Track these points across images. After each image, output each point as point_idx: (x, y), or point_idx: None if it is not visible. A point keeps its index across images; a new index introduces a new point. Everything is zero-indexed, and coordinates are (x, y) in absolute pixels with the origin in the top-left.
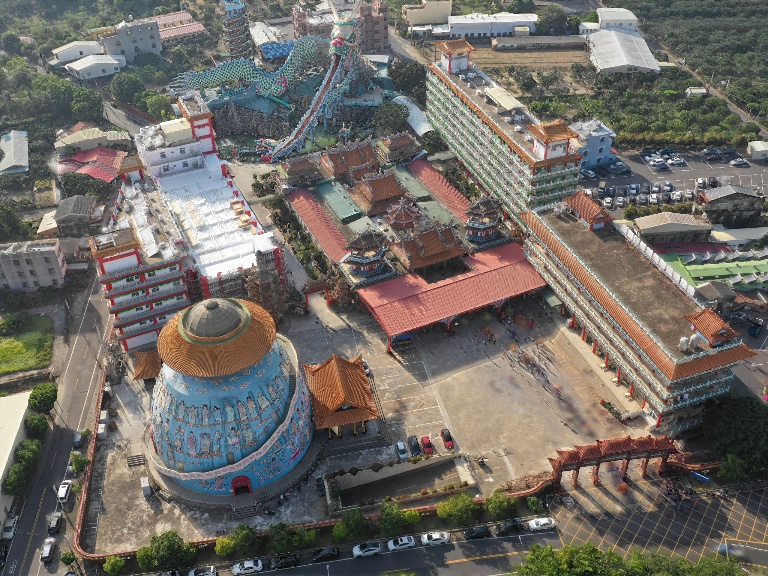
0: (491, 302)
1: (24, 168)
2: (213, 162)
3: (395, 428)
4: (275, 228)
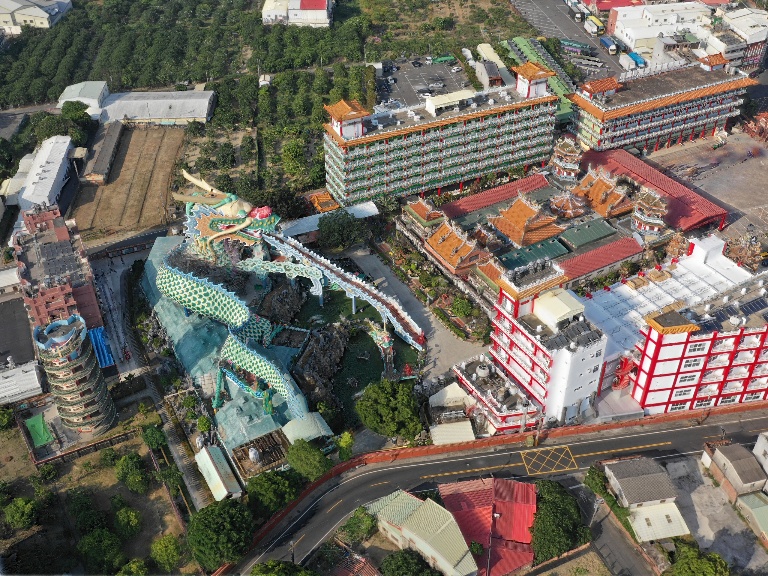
0: None
1: None
2: None
3: None
4: None
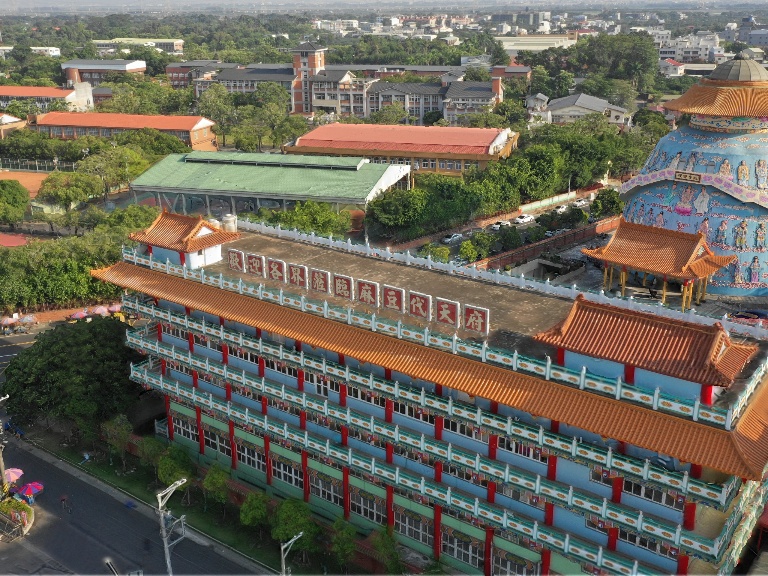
0: None
1: None
2: None
3: None
4: None
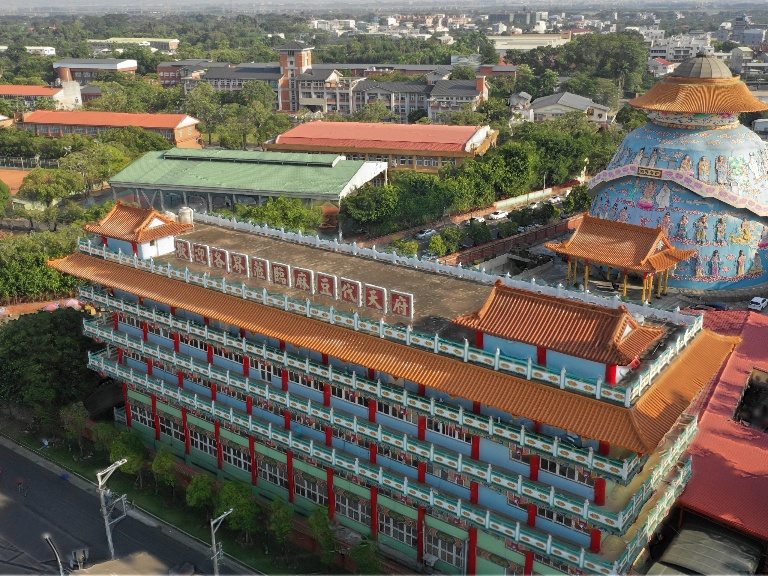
0: None
1: None
2: None
3: None
4: None
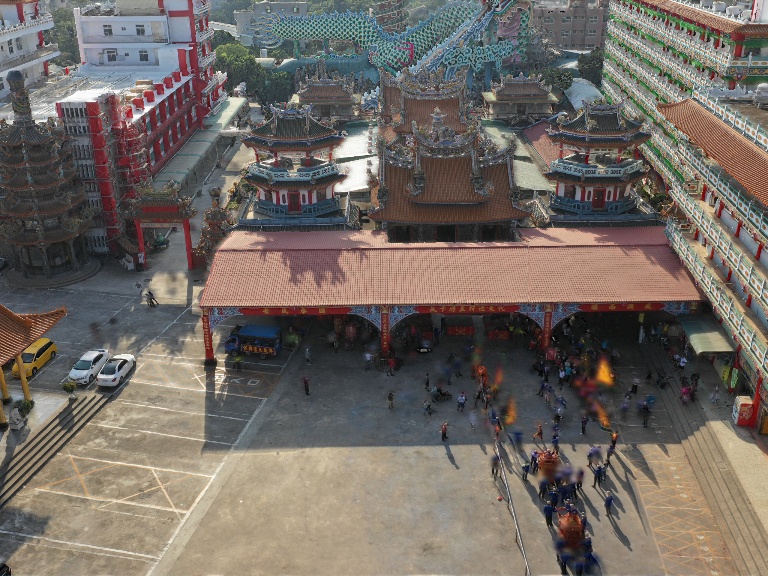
0: (516, 301)
1: None
2: (172, 47)
3: (5, 528)
4: (240, 173)
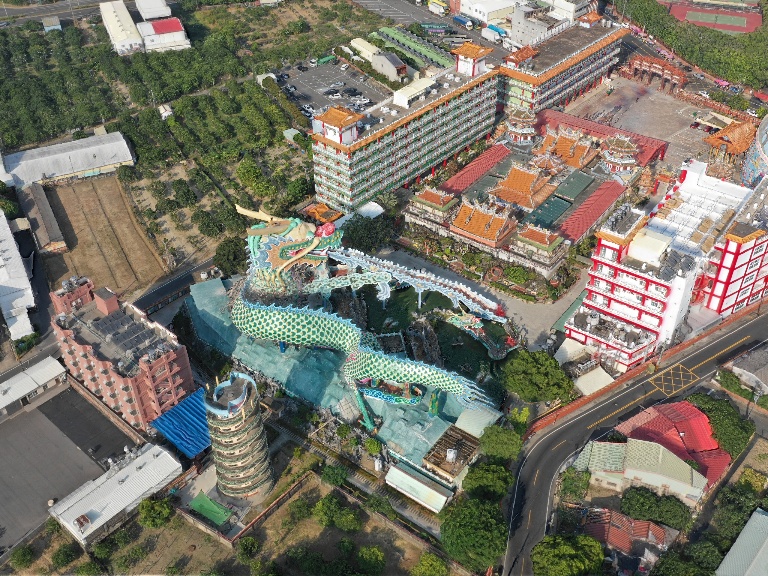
0: None
1: (764, 514)
2: None
3: None
4: None
